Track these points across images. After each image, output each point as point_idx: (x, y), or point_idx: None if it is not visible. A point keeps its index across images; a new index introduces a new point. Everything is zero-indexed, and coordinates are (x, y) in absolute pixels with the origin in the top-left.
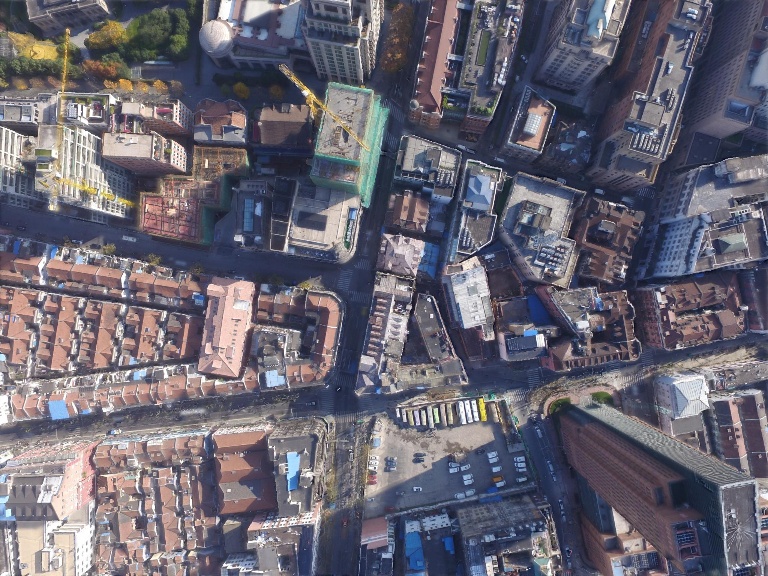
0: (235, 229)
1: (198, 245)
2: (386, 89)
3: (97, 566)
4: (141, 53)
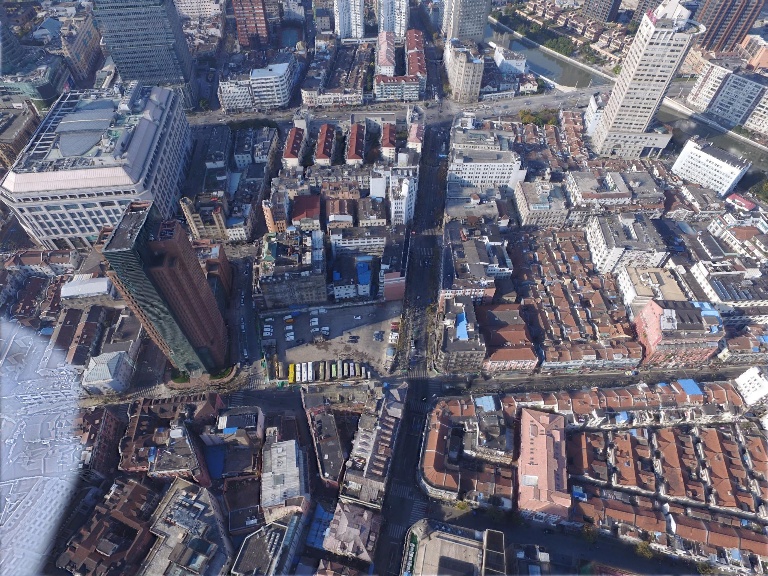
0: None
1: None
2: None
3: (613, 278)
4: None
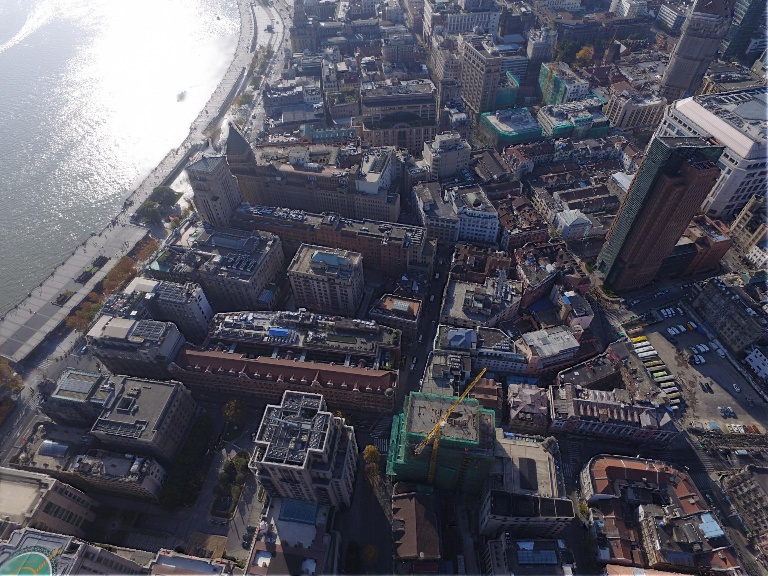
0: None
1: None
2: (360, 436)
3: None
4: None
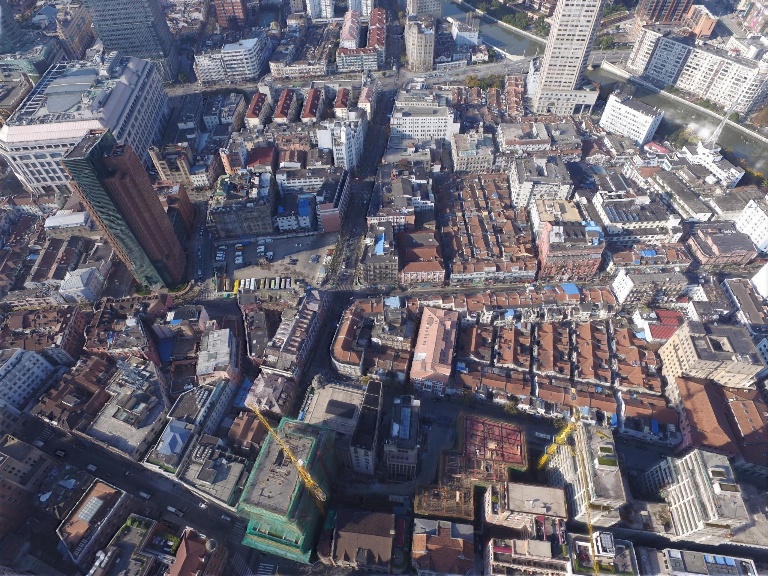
0: None
1: None
2: None
3: None
4: None
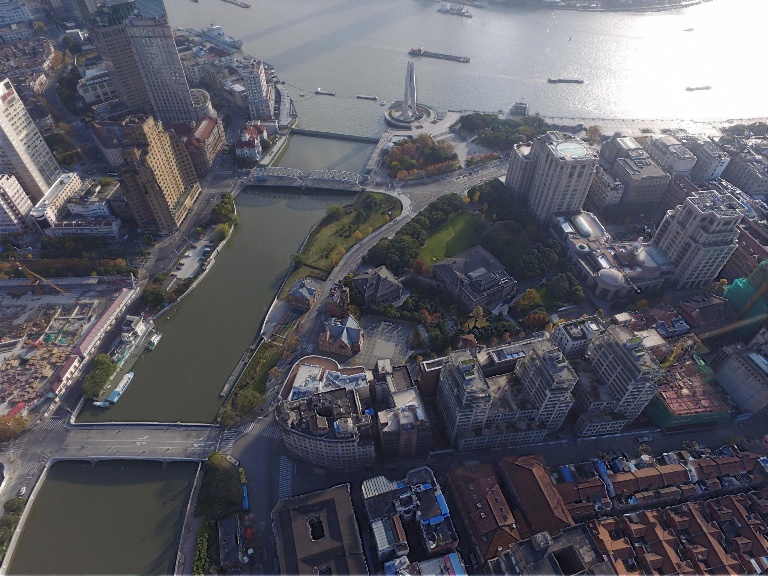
0: (762, 379)
1: (707, 424)
2: None
3: None
4: (558, 303)
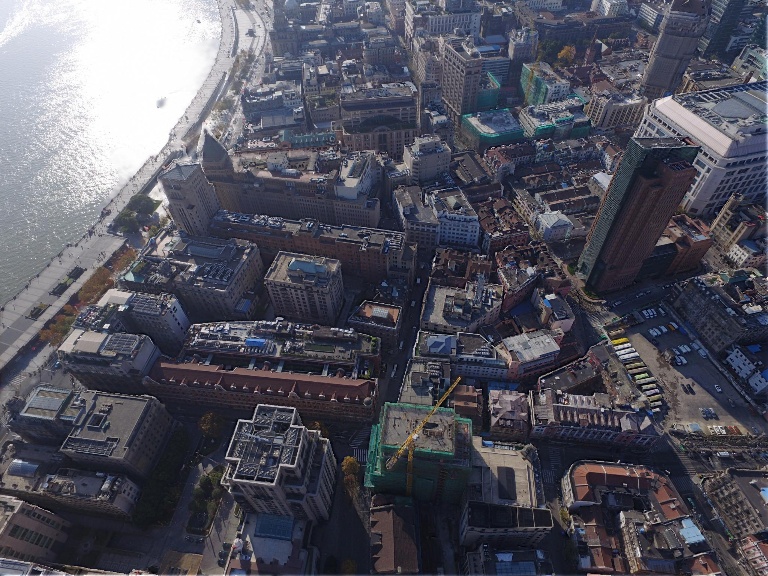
0: None
1: None
2: (339, 446)
3: None
4: None
